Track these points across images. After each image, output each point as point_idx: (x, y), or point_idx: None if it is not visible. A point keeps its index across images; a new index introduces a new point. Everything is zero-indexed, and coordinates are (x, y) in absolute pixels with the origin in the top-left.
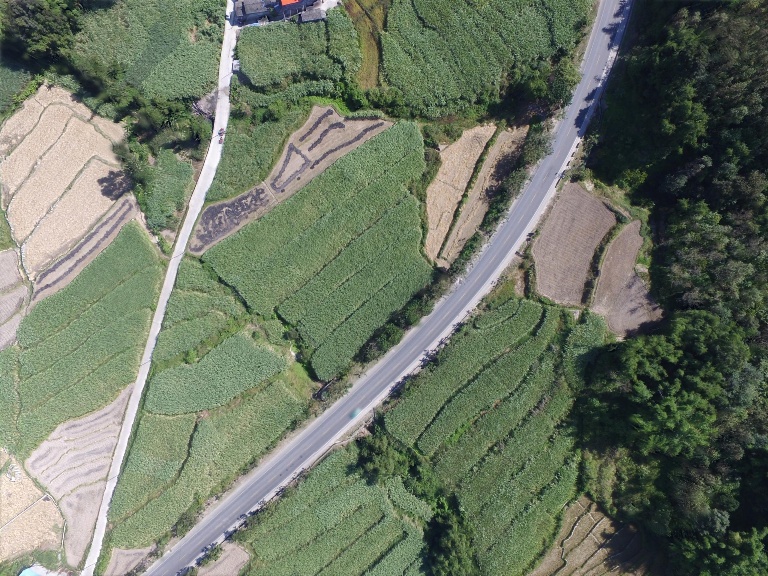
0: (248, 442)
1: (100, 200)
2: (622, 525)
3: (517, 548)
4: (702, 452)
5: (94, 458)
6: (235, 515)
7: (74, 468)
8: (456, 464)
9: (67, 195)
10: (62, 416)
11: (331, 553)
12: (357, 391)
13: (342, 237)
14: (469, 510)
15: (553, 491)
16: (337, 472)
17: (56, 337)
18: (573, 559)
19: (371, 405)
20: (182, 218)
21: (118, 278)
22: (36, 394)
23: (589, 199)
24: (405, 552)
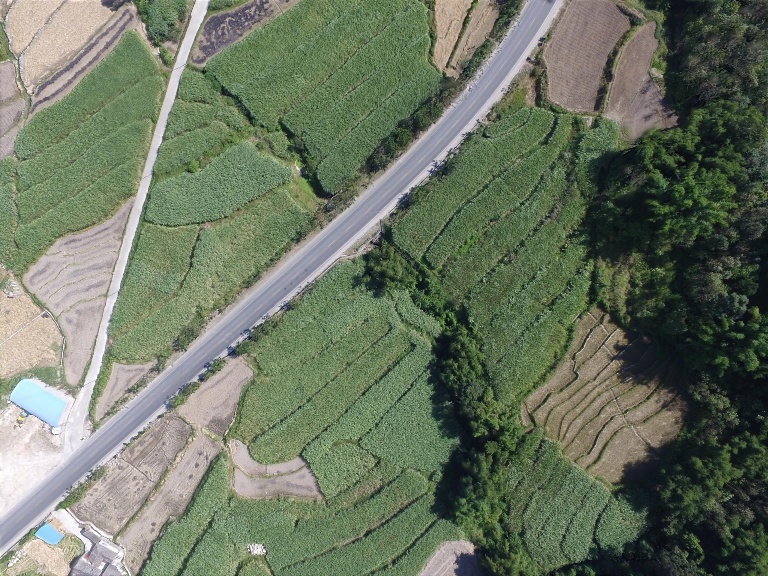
0: (252, 252)
1: (100, 10)
2: (636, 336)
3: (528, 359)
4: (721, 231)
5: (94, 274)
6: (238, 330)
7: (73, 283)
8: (465, 274)
9: (66, 5)
10: (61, 228)
11: (337, 367)
12: (364, 202)
13: (348, 46)
14: (479, 321)
15: (565, 301)
16: (343, 283)
17: (55, 147)
18: (585, 372)
19: (378, 217)
20: (184, 29)
21: (118, 88)
22: (34, 205)
23: (603, 2)
24: (413, 364)
